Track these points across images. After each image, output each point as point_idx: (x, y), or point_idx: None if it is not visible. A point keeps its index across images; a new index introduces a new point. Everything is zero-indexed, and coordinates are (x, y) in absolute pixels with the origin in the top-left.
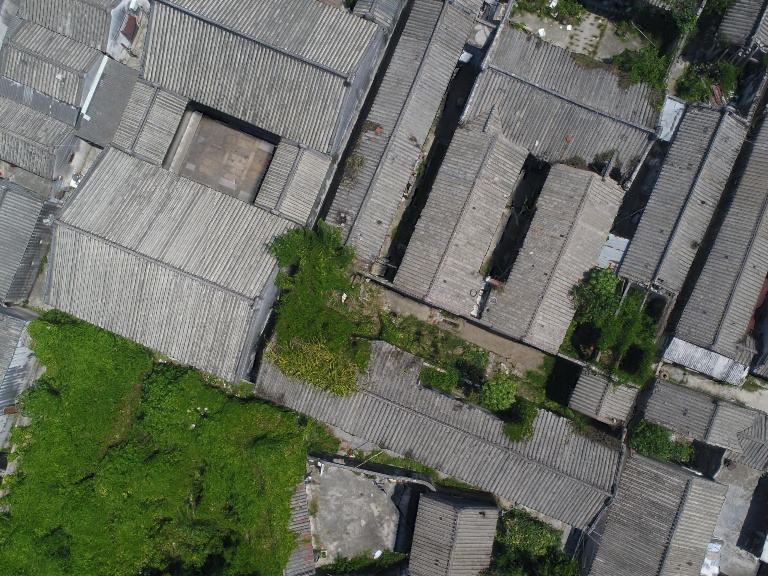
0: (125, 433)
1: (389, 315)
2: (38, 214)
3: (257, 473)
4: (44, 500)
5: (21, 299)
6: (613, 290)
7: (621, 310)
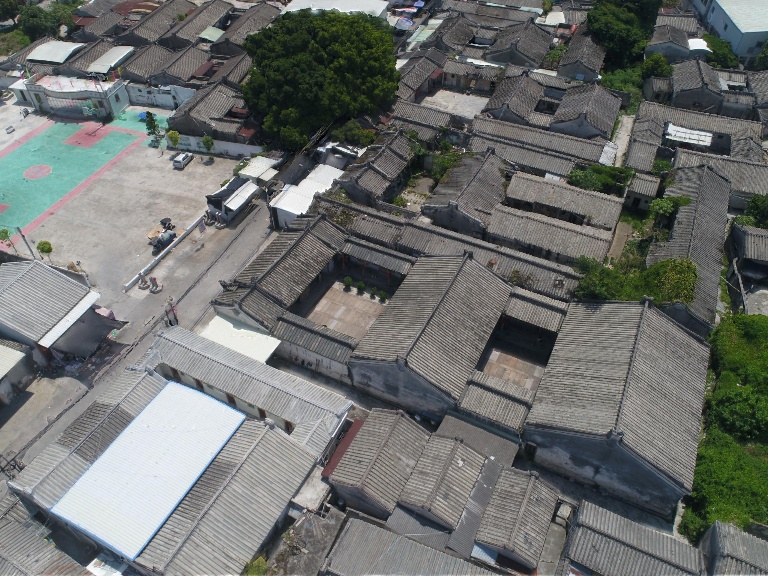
0: None
1: None
2: (597, 506)
3: None
4: None
5: None
6: None
7: None
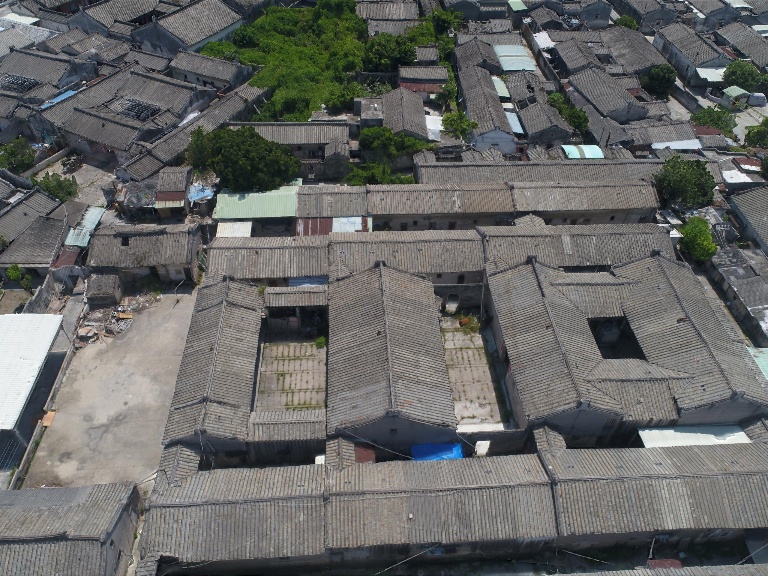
0: None
1: None
2: None
3: None
4: None
5: None
6: None
7: None
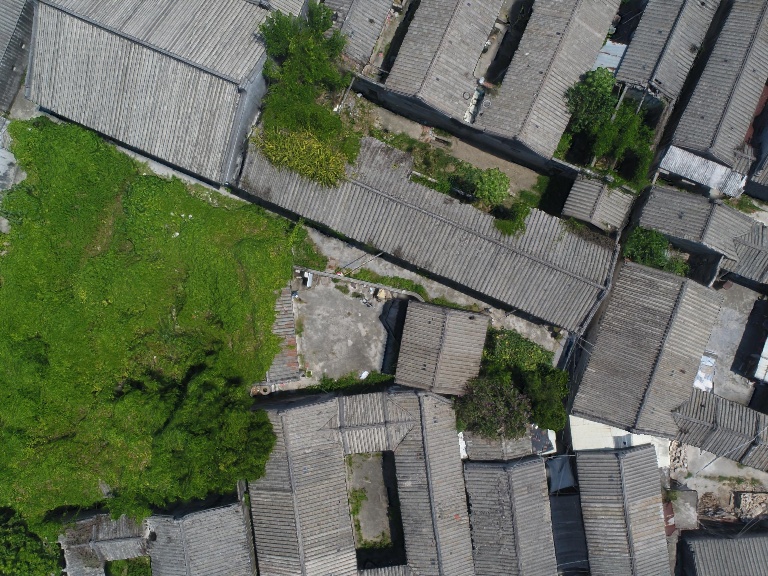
0: (107, 244)
1: (380, 131)
2: (20, 10)
3: (241, 274)
4: (21, 304)
5: (2, 107)
6: (609, 89)
7: (617, 118)
